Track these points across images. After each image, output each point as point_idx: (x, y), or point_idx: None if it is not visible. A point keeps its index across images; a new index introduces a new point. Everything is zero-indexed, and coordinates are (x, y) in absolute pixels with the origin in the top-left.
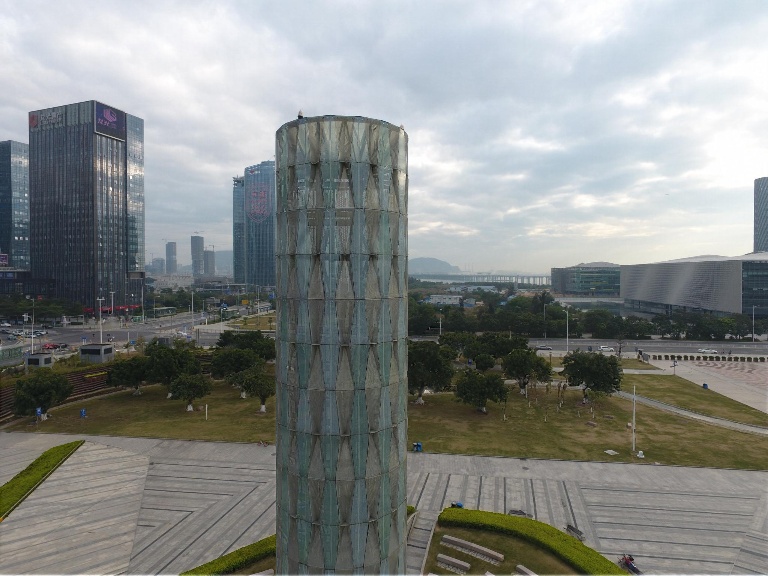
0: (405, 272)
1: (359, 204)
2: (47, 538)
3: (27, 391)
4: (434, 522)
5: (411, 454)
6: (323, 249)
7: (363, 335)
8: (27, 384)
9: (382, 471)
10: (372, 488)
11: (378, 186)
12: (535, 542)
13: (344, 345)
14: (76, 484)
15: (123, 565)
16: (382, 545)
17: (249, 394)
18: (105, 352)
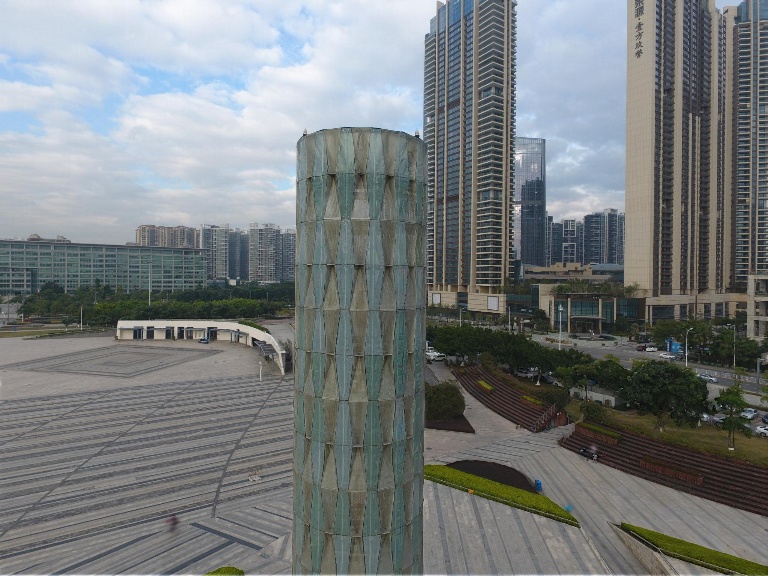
0: (300, 281)
1: None
2: None
3: None
4: None
5: None
6: None
7: None
8: None
9: None
10: None
11: None
12: None
13: None
14: None
15: None
16: None
17: None
18: None
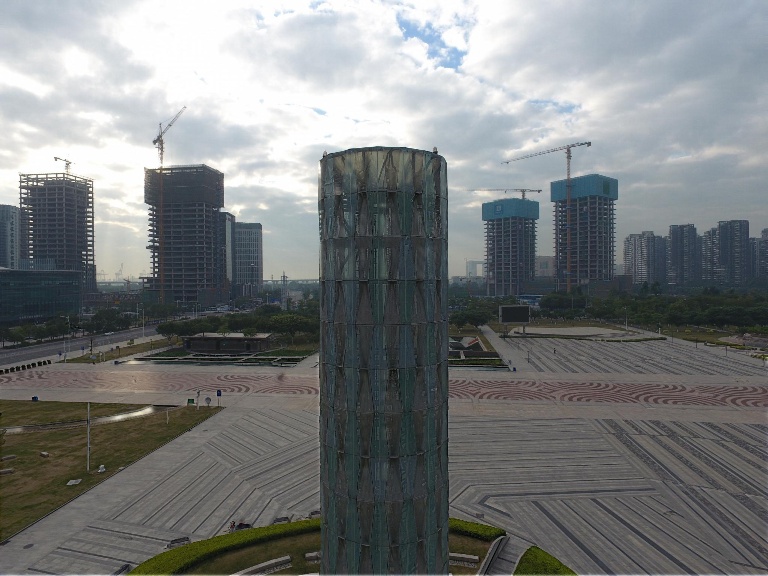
0: None
1: None
2: None
3: None
4: None
5: None
6: None
7: None
8: None
9: None
10: None
11: None
12: (207, 557)
13: None
14: None
15: None
16: None
17: None
18: None
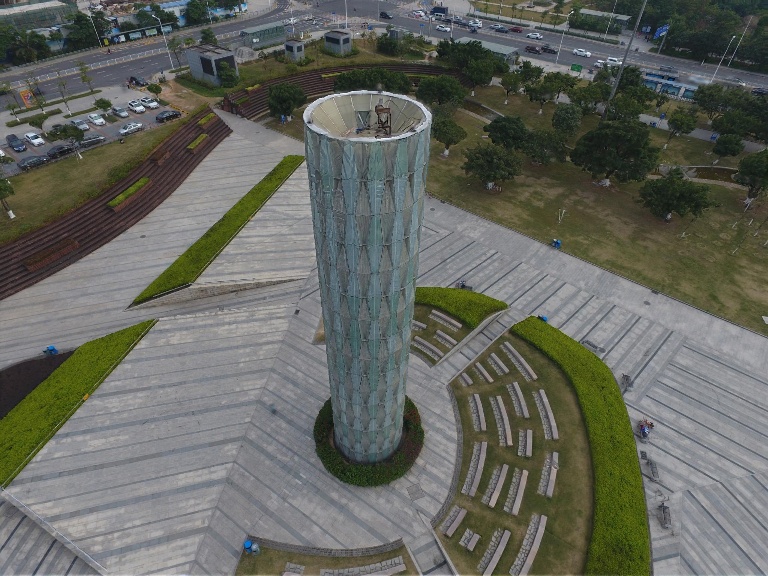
0: (407, 246)
1: (352, 210)
2: (272, 239)
3: (274, 99)
4: (508, 328)
5: (547, 248)
6: (328, 233)
7: (357, 292)
8: (274, 93)
9: (372, 358)
10: (365, 363)
11: (369, 198)
12: (570, 380)
13: (343, 294)
14: (294, 199)
15: (307, 273)
16: (373, 385)
17: (435, 138)
18: (343, 42)
